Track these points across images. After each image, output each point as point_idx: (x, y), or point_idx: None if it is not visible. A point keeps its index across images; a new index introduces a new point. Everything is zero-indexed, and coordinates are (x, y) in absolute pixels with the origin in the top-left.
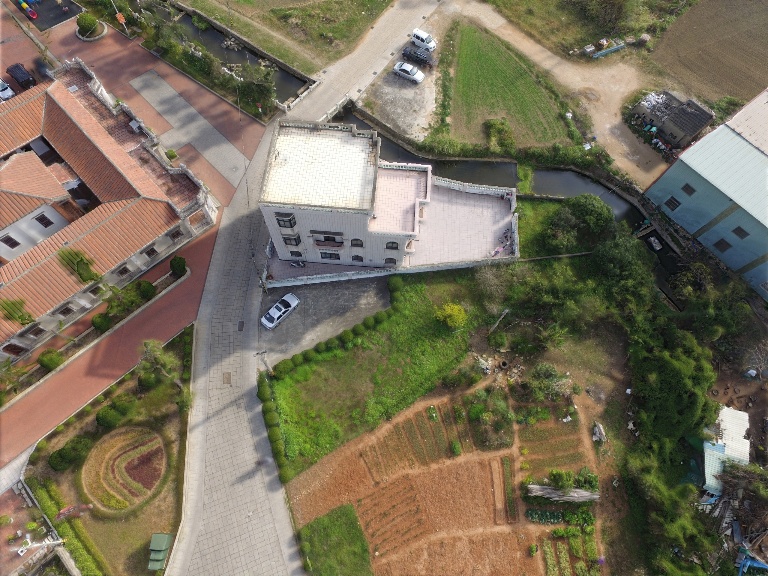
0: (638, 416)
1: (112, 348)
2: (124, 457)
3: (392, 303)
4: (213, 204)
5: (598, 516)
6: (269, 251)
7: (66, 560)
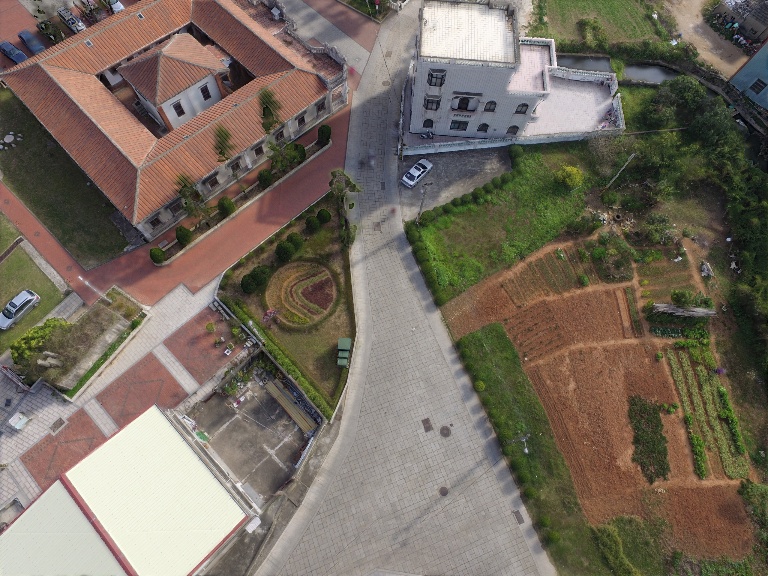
0: (741, 255)
1: (274, 202)
2: (299, 285)
3: (514, 168)
4: None
5: (712, 333)
6: (402, 123)
7: (270, 355)
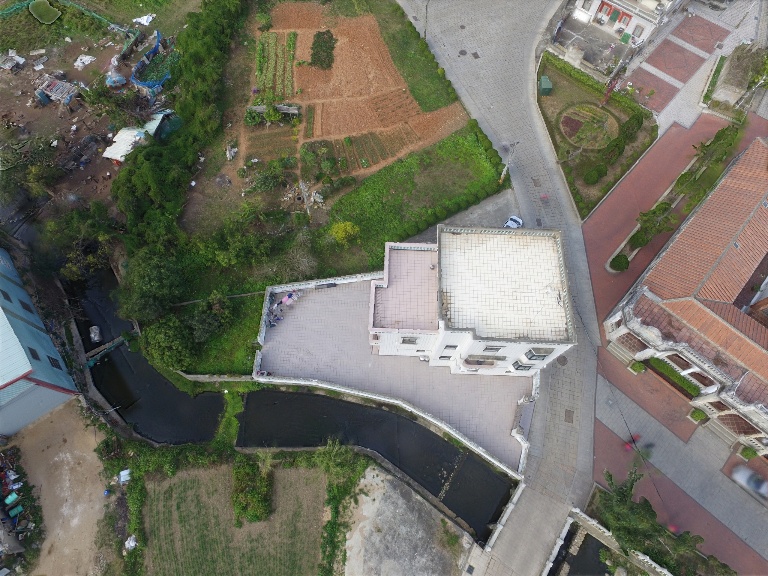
0: None
1: (642, 200)
2: None
3: None
4: (616, 344)
5: None
6: None
7: (600, 75)
